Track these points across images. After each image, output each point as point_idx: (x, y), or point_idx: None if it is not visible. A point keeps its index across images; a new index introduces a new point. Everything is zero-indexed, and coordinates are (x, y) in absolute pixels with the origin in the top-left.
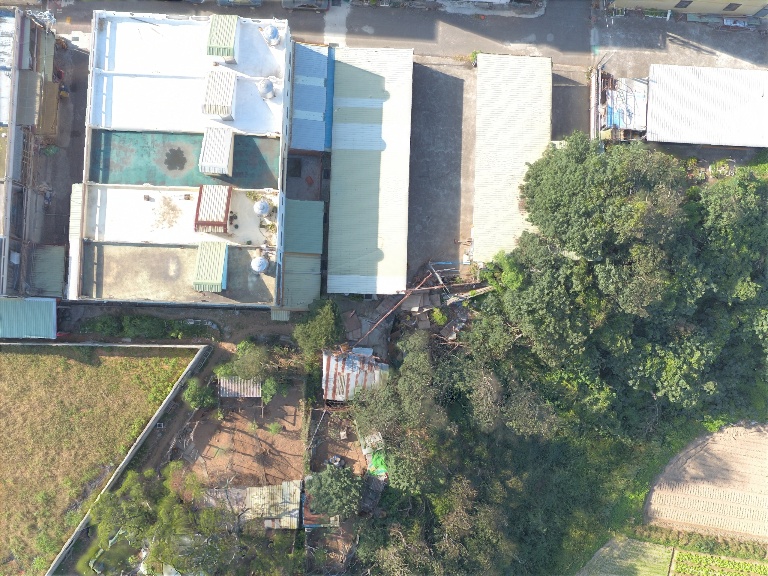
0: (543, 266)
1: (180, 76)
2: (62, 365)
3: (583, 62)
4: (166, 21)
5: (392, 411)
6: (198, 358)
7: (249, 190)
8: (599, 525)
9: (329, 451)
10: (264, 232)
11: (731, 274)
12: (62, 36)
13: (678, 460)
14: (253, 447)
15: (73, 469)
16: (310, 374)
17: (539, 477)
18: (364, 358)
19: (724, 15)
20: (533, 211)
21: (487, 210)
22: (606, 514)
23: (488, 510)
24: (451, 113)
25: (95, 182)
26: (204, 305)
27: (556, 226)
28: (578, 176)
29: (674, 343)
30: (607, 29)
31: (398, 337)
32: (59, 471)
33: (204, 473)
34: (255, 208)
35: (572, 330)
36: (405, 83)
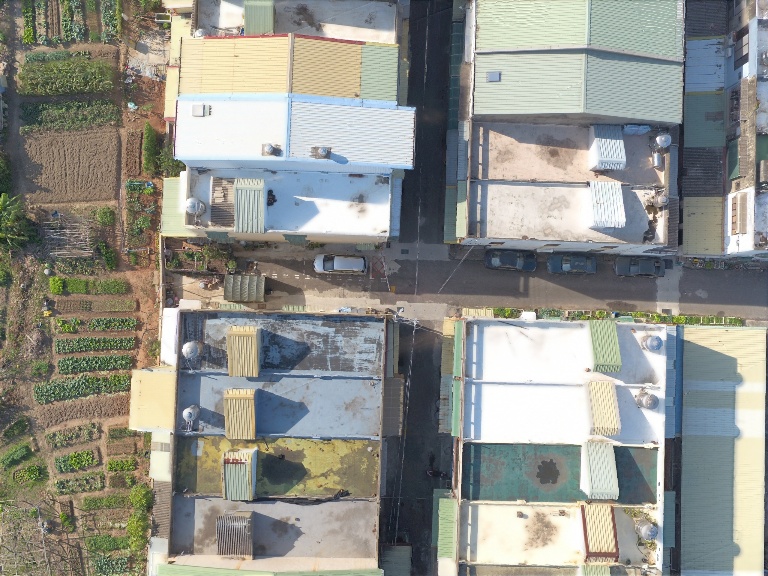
0: None
1: None
2: None
3: None
4: (535, 324)
5: None
6: None
7: (628, 507)
8: None
9: None
10: (642, 549)
11: None
12: (387, 307)
13: None
14: None
15: None
16: None
17: None
18: None
19: None
20: None
21: None
22: None
23: None
24: None
25: (467, 499)
26: None
27: None
28: None
29: None
30: None
31: None
32: None
33: None
34: (644, 534)
35: None
36: (758, 365)
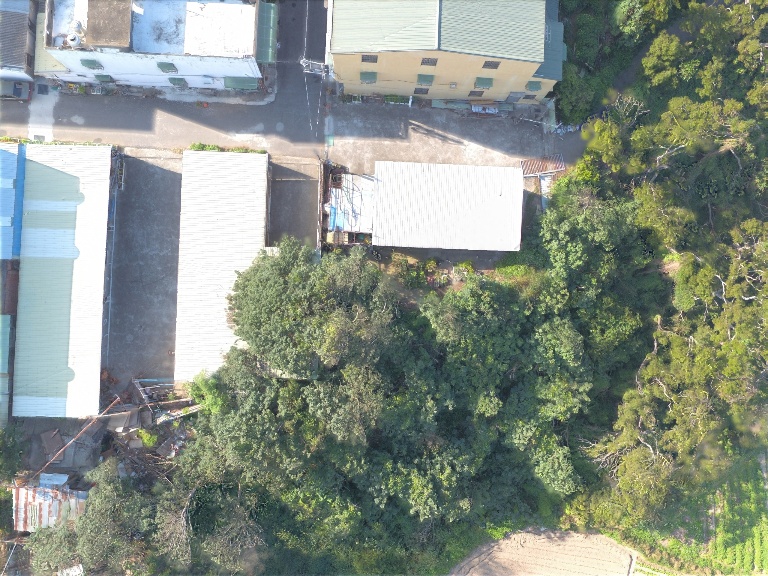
0: (246, 388)
1: None
2: None
3: None
4: None
5: (65, 554)
6: None
7: None
8: None
9: None
10: None
11: (477, 386)
12: None
13: (460, 569)
14: None
15: None
16: (7, 500)
17: None
18: (57, 486)
19: (471, 101)
20: (242, 324)
21: (191, 323)
22: None
23: None
24: (168, 211)
25: None
26: None
27: (259, 344)
28: (274, 292)
29: (422, 458)
30: (343, 117)
31: (112, 455)
32: None
33: None
34: None
35: (286, 455)
36: (102, 184)
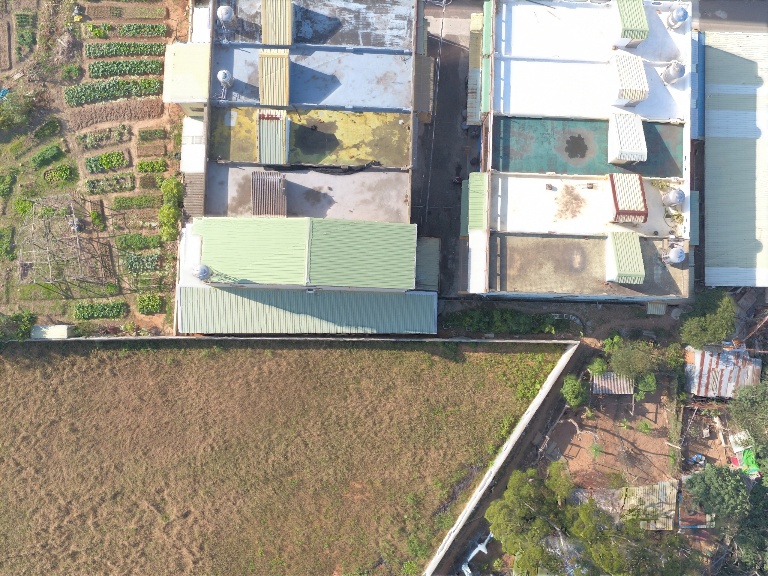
0: None
1: (579, 60)
2: (428, 362)
3: None
4: (562, 4)
5: None
6: None
7: (655, 178)
8: None
9: (690, 450)
10: (669, 222)
11: None
12: None
13: None
14: (615, 446)
15: (442, 469)
16: (673, 370)
17: None
18: (738, 353)
19: None
20: None
21: None
22: None
23: None
24: None
25: (497, 170)
26: (566, 299)
27: None
28: None
29: None
30: None
31: None
32: (428, 472)
33: (567, 473)
34: (672, 197)
35: None
36: None
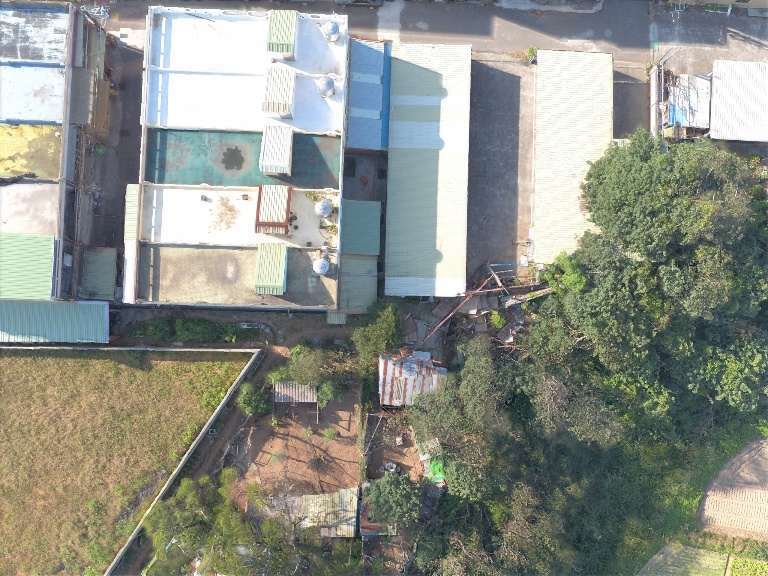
0: (607, 267)
1: (237, 73)
2: (113, 370)
3: (642, 58)
4: (222, 17)
5: (454, 417)
6: (252, 362)
7: (309, 190)
8: (653, 532)
9: (384, 457)
10: (324, 233)
11: None
12: (110, 33)
13: (732, 465)
14: (307, 453)
15: (125, 476)
16: (365, 378)
17: (592, 483)
18: (422, 362)
19: None
20: (595, 211)
21: (548, 210)
22: (660, 520)
23: (546, 517)
24: (508, 111)
25: (151, 182)
26: (257, 308)
27: (620, 226)
28: (644, 175)
29: (735, 346)
30: (666, 24)
31: (454, 340)
32: (110, 478)
33: (257, 480)
34: (317, 208)
35: (635, 333)
36: (463, 80)
